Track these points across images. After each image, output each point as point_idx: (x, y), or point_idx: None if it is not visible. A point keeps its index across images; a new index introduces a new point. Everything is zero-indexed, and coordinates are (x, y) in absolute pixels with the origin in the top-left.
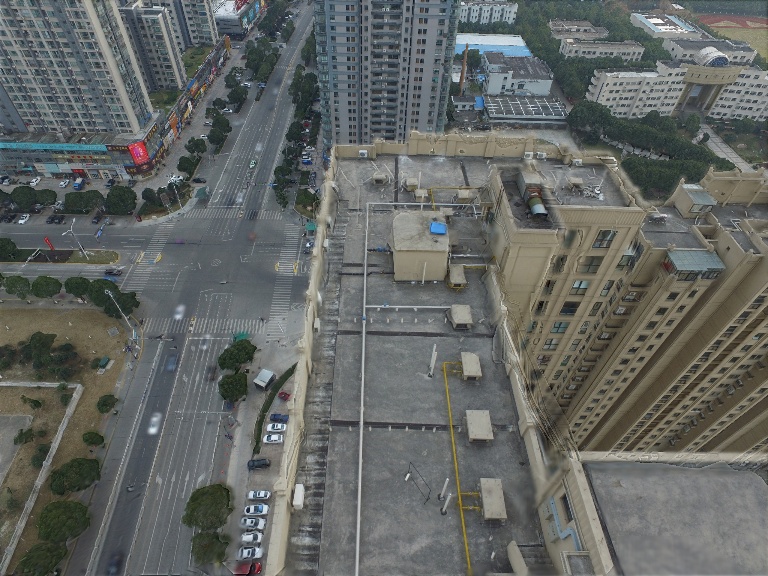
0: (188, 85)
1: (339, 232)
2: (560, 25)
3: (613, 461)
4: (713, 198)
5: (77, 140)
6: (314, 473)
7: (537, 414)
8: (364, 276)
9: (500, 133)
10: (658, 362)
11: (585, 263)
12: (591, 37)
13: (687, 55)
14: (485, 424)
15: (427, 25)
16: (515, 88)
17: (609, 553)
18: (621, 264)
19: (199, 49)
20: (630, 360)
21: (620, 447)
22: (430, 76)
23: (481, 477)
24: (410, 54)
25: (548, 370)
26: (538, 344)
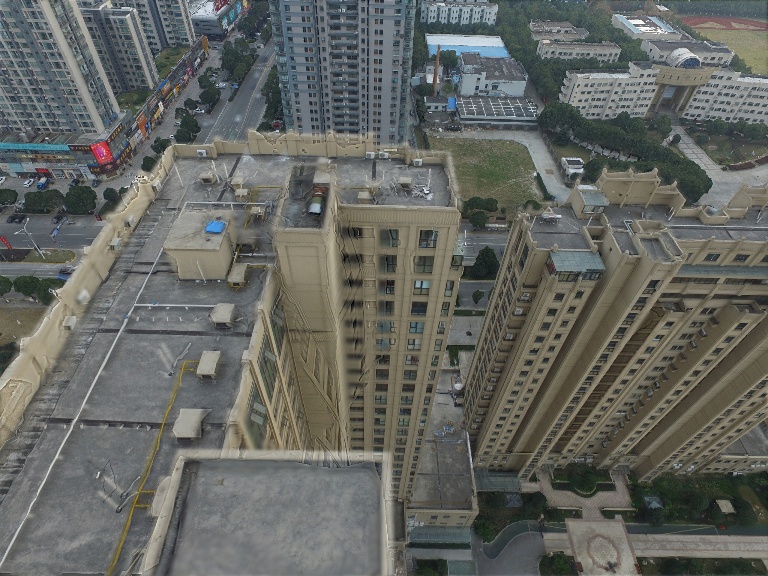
0: (160, 85)
1: (144, 231)
2: (541, 26)
3: (251, 460)
4: (606, 199)
5: (41, 140)
6: (12, 470)
7: (281, 413)
8: (148, 275)
9: (471, 134)
10: (563, 363)
11: (419, 263)
12: (570, 38)
13: (664, 56)
14: (192, 422)
15: (383, 26)
16: (489, 89)
17: (160, 551)
18: (455, 264)
19: (175, 50)
20: (534, 361)
21: (544, 449)
22: (389, 77)
23: (168, 475)
24: (368, 55)
25: (420, 370)
26: (400, 344)
